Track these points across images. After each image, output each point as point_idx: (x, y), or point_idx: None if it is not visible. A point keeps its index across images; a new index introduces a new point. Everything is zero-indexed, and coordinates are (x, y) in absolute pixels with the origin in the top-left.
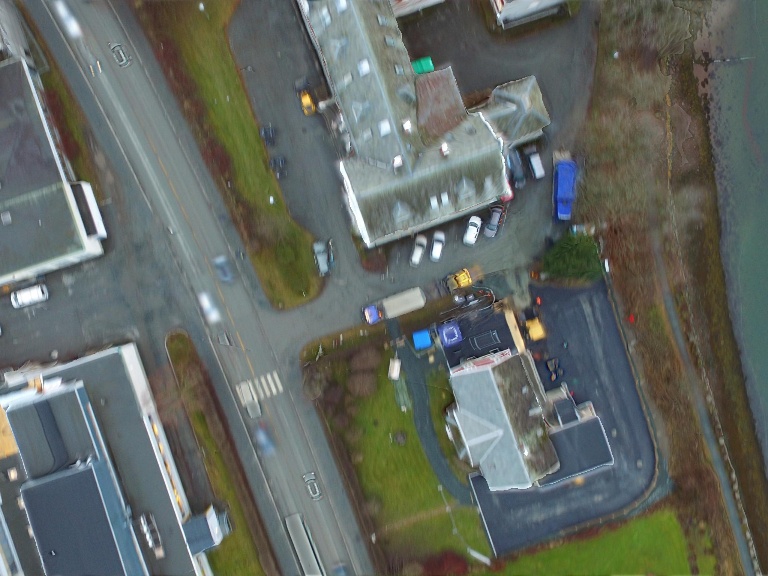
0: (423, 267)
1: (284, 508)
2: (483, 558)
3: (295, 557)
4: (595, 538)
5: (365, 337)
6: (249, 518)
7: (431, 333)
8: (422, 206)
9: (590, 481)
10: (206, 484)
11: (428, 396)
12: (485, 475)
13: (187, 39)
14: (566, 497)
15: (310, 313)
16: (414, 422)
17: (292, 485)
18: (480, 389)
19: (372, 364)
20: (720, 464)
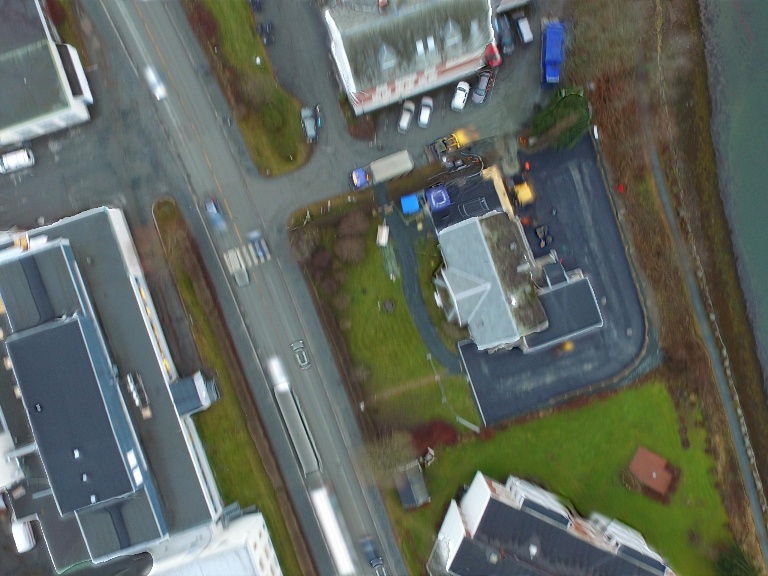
0: (411, 134)
1: (272, 377)
2: (472, 426)
3: (284, 426)
4: (585, 408)
5: (353, 204)
6: (237, 385)
7: (419, 199)
8: (408, 51)
9: (580, 349)
10: (194, 352)
11: (417, 264)
12: (473, 334)
13: None
14: (556, 365)
15: (298, 181)
16: (403, 290)
17: (280, 353)
18: (468, 243)
19: (360, 229)
20: (711, 341)
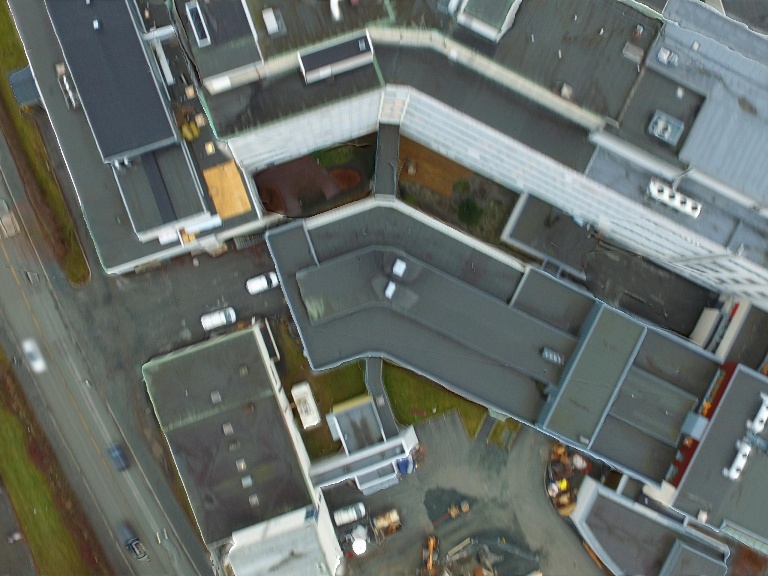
0: None
1: None
2: None
3: None
4: None
5: None
6: None
7: None
8: None
9: None
10: (46, 134)
11: None
12: None
13: (76, 567)
14: None
15: None
16: None
17: None
18: None
19: None
20: None
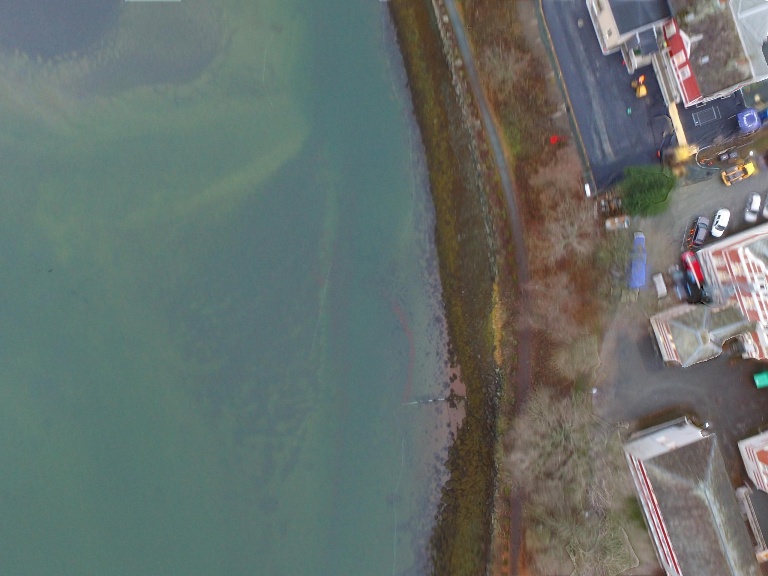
0: (764, 188)
1: None
2: None
3: None
4: None
5: None
6: None
7: (761, 123)
8: None
9: None
10: None
11: None
12: None
13: None
14: None
15: None
16: None
17: None
18: None
19: None
20: None
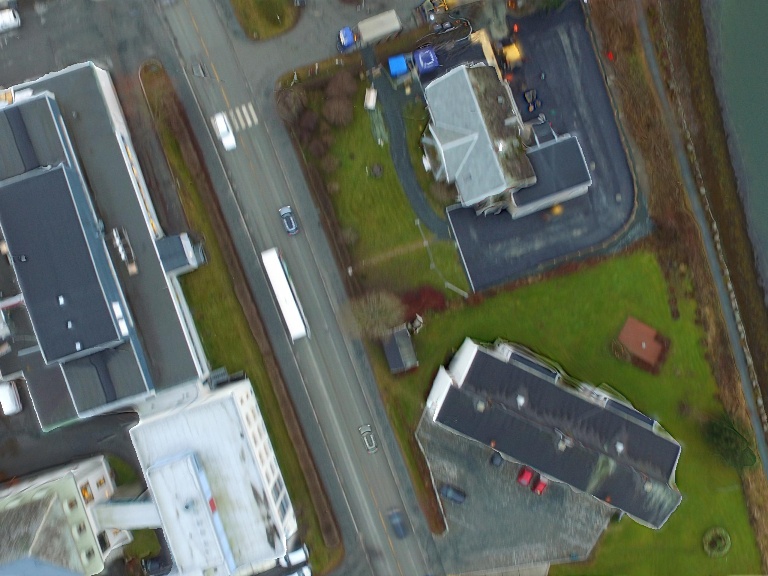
0: None
1: (260, 242)
2: (461, 291)
3: (271, 292)
4: (574, 275)
5: (341, 67)
6: (224, 248)
7: (407, 62)
8: None
9: (569, 215)
10: (181, 216)
11: (405, 128)
12: (461, 189)
13: None
14: (544, 231)
15: (285, 45)
16: (391, 155)
17: (268, 218)
18: (455, 93)
19: (347, 90)
20: (701, 215)
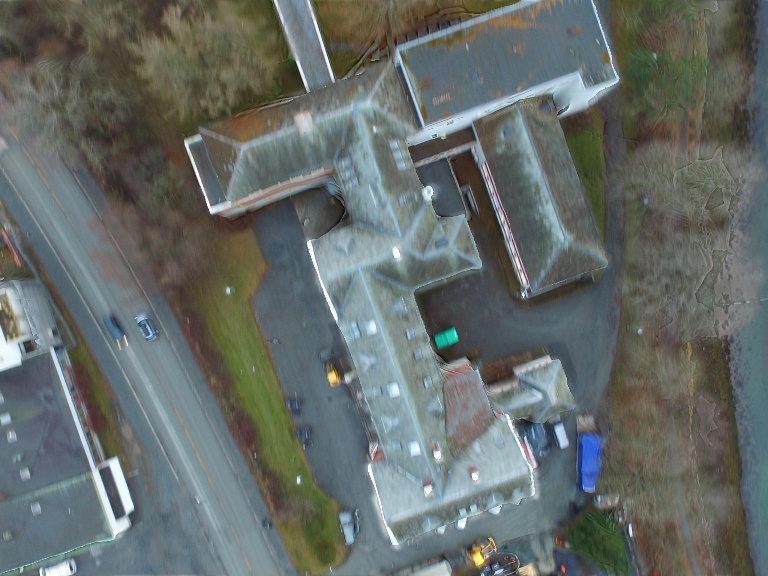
0: (448, 533)
1: None
2: None
3: None
4: None
5: None
6: None
7: None
8: (451, 515)
9: None
10: None
11: None
12: None
13: (213, 311)
14: None
15: None
16: None
17: None
18: None
19: None
20: None
